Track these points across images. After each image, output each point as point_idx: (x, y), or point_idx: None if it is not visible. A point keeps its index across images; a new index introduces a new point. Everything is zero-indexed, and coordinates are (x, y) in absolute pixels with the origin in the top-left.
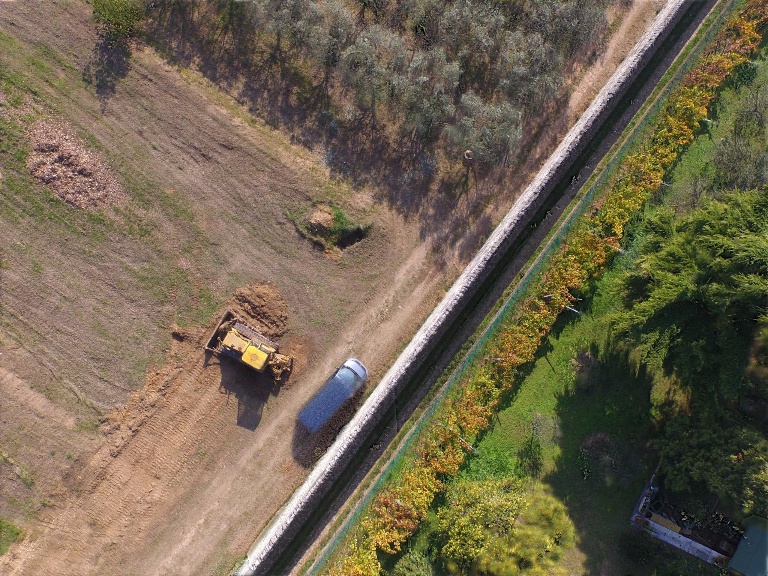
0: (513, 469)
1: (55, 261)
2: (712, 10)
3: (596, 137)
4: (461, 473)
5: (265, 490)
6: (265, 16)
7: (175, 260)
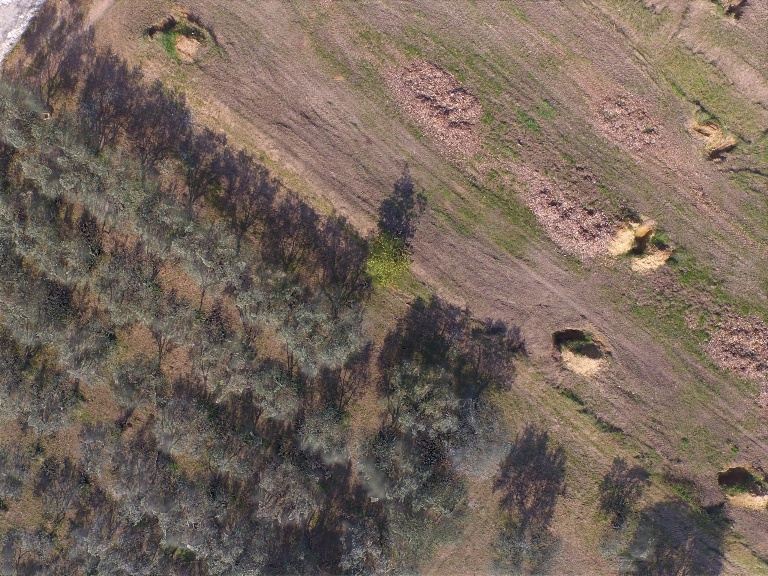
0: None
1: (454, 7)
2: None
3: None
4: None
5: None
6: (252, 272)
7: (335, 6)
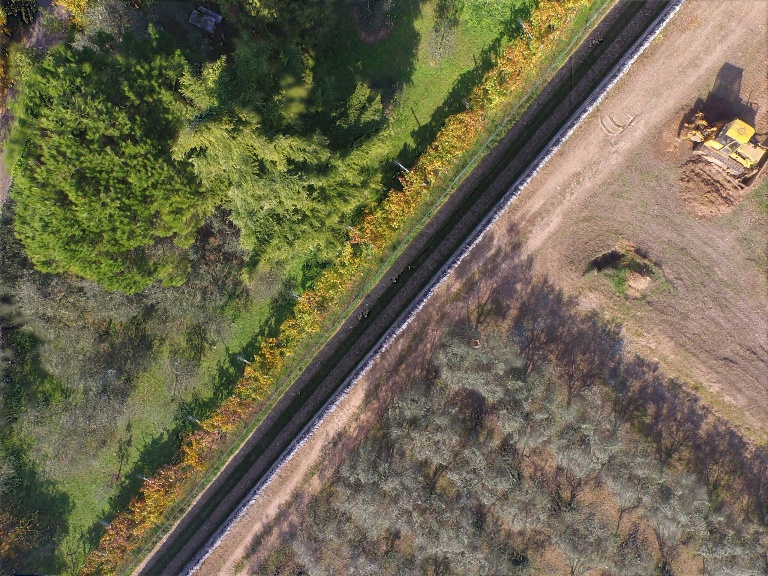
0: (465, 8)
1: None
2: (209, 485)
3: (340, 358)
4: (521, 6)
5: (719, 0)
6: None
7: None
